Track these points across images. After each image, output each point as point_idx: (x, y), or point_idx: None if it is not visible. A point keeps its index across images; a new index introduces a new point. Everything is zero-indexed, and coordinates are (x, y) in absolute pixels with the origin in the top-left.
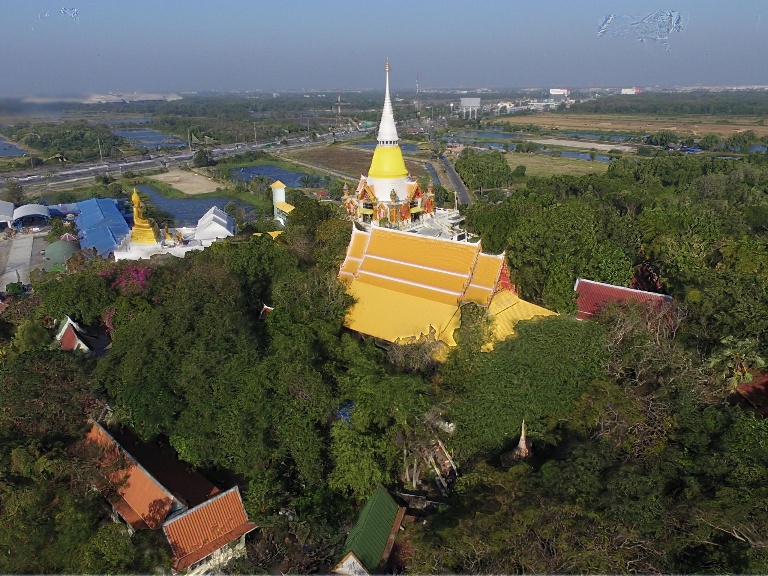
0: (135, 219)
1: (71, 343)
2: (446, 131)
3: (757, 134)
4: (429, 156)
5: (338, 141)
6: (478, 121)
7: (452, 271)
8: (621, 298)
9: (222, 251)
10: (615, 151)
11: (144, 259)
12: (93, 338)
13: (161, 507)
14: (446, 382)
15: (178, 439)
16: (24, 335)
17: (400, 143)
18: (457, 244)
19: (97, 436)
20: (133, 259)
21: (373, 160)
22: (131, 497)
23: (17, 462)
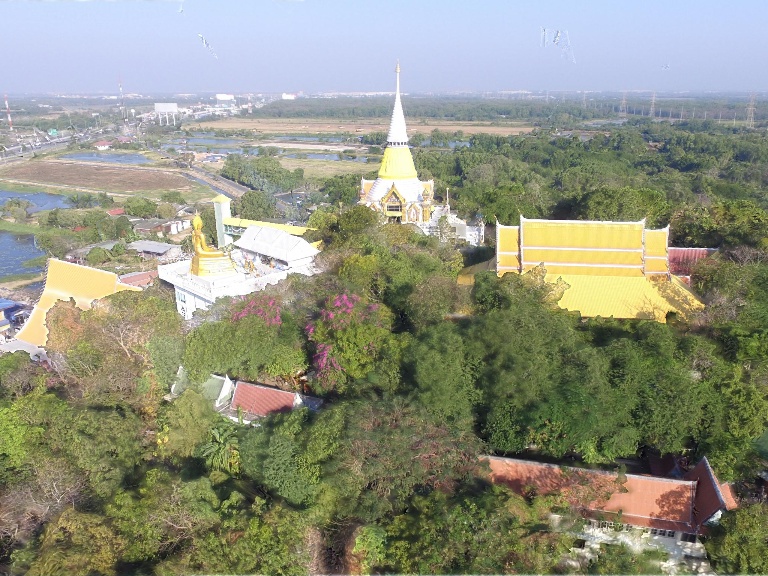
0: (200, 248)
1: (275, 401)
2: (159, 138)
3: None
4: (173, 165)
5: (38, 154)
6: (178, 127)
7: (625, 248)
8: (675, 256)
9: (371, 266)
10: (349, 151)
11: (256, 291)
12: None
13: (678, 497)
14: (720, 334)
15: (587, 443)
16: (195, 409)
17: (117, 153)
18: (622, 225)
19: (506, 469)
20: (231, 295)
21: (388, 162)
22: (619, 505)
23: (521, 512)
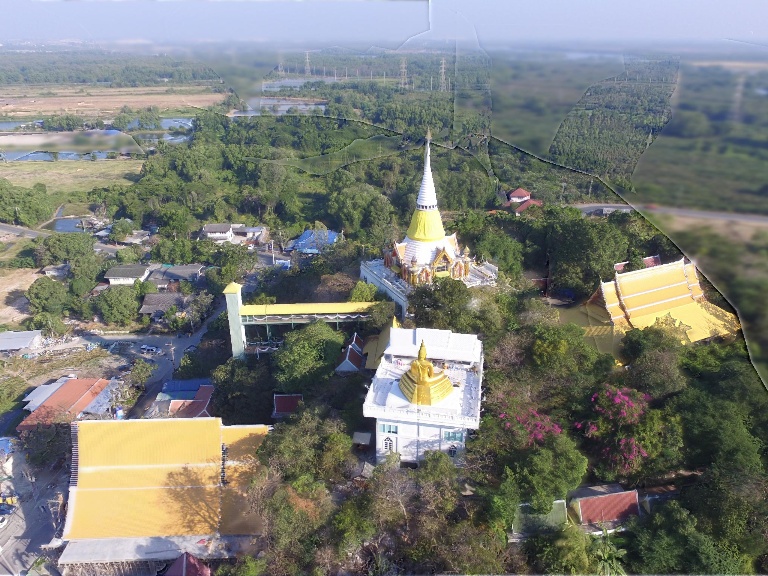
0: (427, 377)
1: (621, 503)
2: None
3: (132, 108)
4: None
5: None
6: None
7: None
8: None
9: None
10: None
11: (501, 405)
12: (574, 500)
13: None
14: None
15: None
16: None
17: None
18: None
19: None
20: None
21: (428, 225)
22: None
23: None
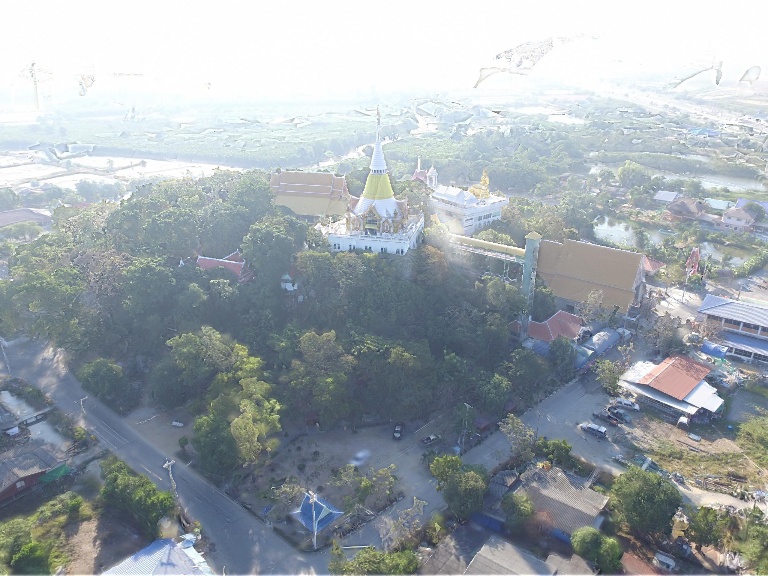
0: None
1: None
2: None
3: None
4: None
5: None
6: None
7: None
8: None
9: None
10: None
11: None
12: None
13: None
14: None
15: None
16: None
17: None
18: None
19: None
20: None
21: None
22: None
23: None
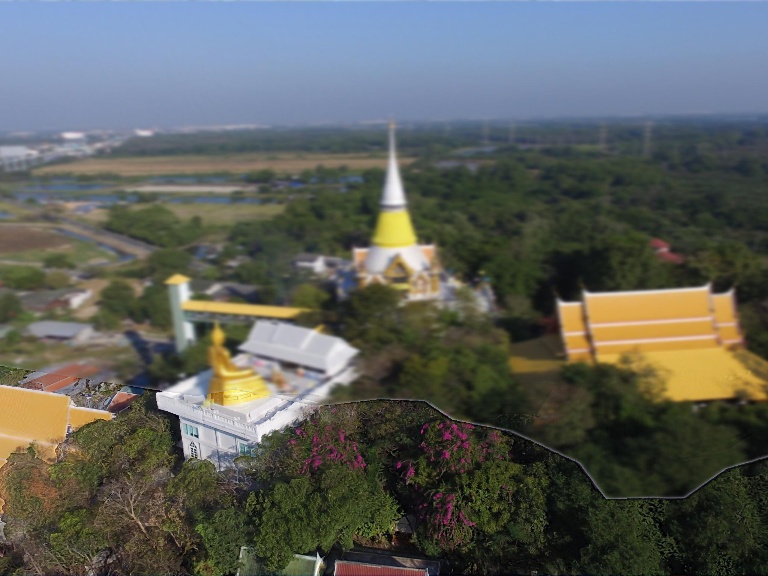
0: None
1: None
2: None
3: None
4: None
5: None
6: None
7: None
8: None
9: None
10: None
11: (311, 420)
12: None
13: None
14: None
15: None
16: None
17: None
18: None
19: None
20: (276, 428)
21: None
22: None
23: None
